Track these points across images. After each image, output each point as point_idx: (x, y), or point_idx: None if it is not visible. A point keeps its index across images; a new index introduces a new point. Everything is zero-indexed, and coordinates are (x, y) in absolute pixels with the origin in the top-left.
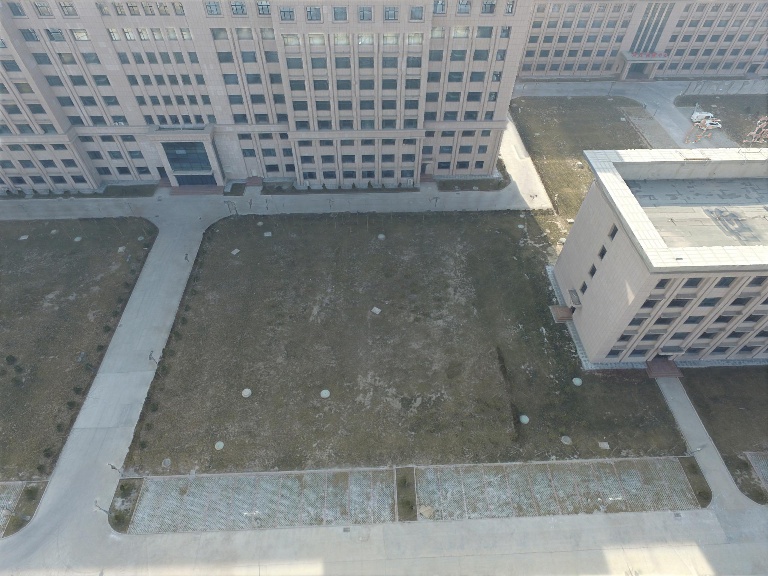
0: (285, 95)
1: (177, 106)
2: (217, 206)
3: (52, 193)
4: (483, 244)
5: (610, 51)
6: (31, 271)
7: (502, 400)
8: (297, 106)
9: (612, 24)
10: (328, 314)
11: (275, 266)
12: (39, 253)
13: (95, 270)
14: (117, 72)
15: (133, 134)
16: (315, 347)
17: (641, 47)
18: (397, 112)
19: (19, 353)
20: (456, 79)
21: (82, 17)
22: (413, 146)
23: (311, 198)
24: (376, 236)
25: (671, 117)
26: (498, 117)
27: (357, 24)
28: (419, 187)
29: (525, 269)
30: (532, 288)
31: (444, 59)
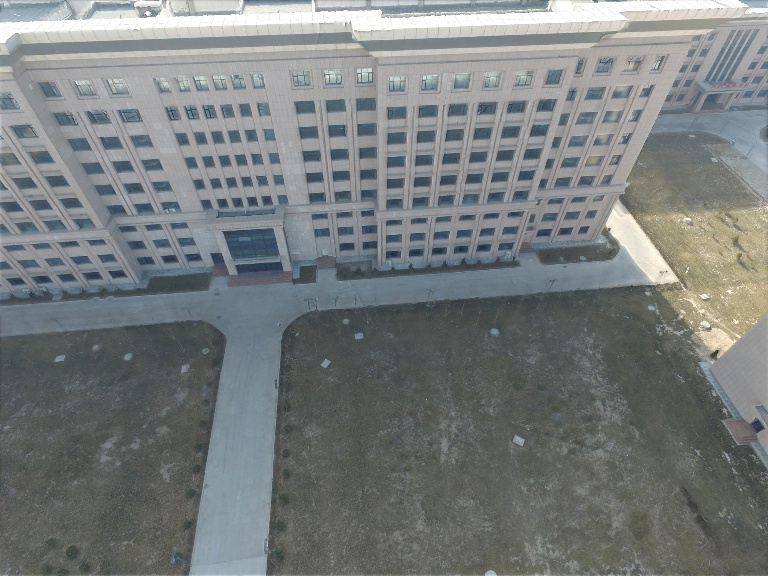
0: (380, 173)
1: (243, 188)
2: (289, 299)
3: (85, 292)
4: (615, 335)
5: (684, 81)
6: (77, 408)
7: (714, 570)
8: (391, 184)
9: (689, 53)
10: (461, 450)
11: (379, 382)
12: (82, 380)
13: (157, 401)
14: (173, 155)
15: (186, 221)
16: (459, 502)
17: (717, 76)
18: (508, 184)
19: (81, 539)
20: (576, 143)
21: (135, 95)
22: (518, 218)
23: (397, 282)
24: (488, 331)
25: (765, 155)
26: (616, 181)
27: (481, 92)
28: (518, 260)
29: (675, 368)
30: (693, 395)
31: (569, 123)
